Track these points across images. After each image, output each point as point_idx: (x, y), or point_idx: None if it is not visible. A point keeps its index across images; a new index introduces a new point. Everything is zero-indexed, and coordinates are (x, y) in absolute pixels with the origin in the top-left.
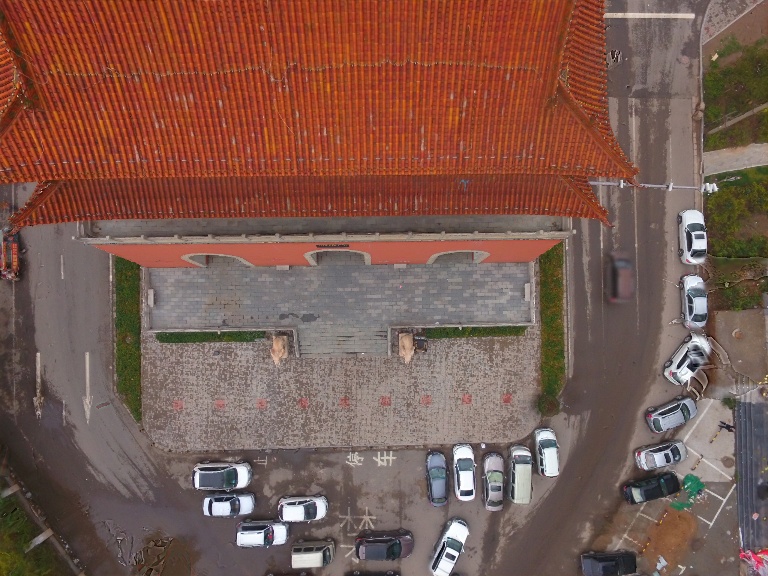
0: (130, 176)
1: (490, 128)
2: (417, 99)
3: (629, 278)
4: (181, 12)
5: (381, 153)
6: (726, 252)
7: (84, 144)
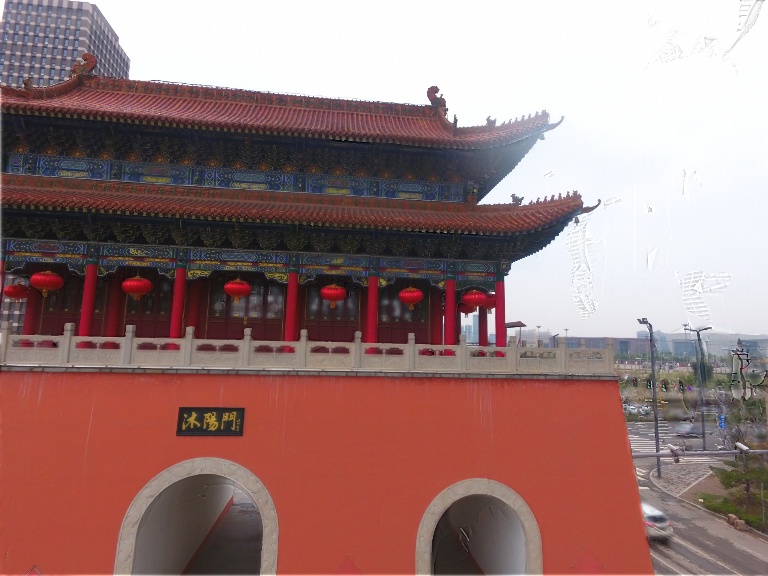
0: (57, 107)
1: None
2: None
3: None
4: None
5: None
6: None
7: None
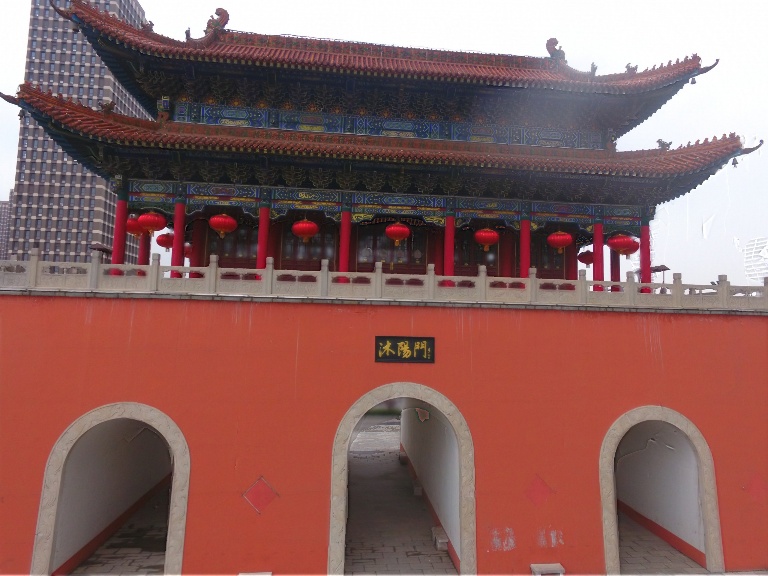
0: (233, 54)
1: None
2: None
3: None
4: None
5: None
6: None
7: None
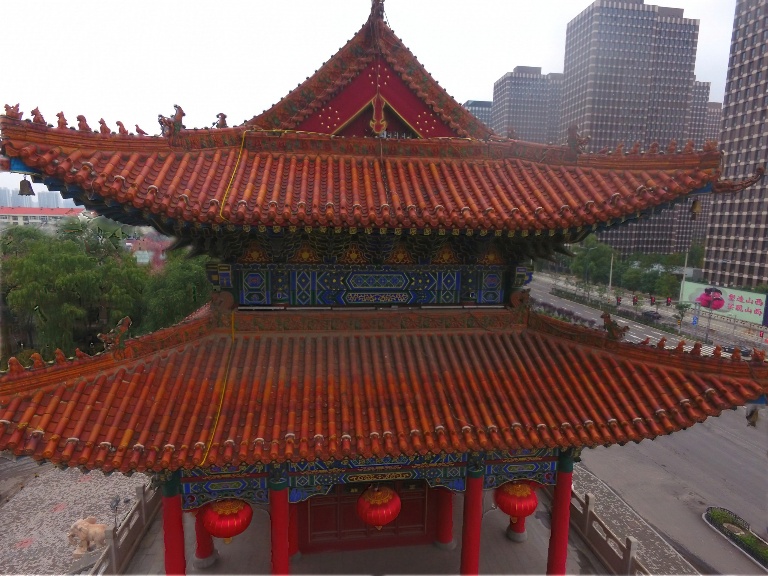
0: None
1: None
2: None
3: None
4: None
5: None
6: None
7: None
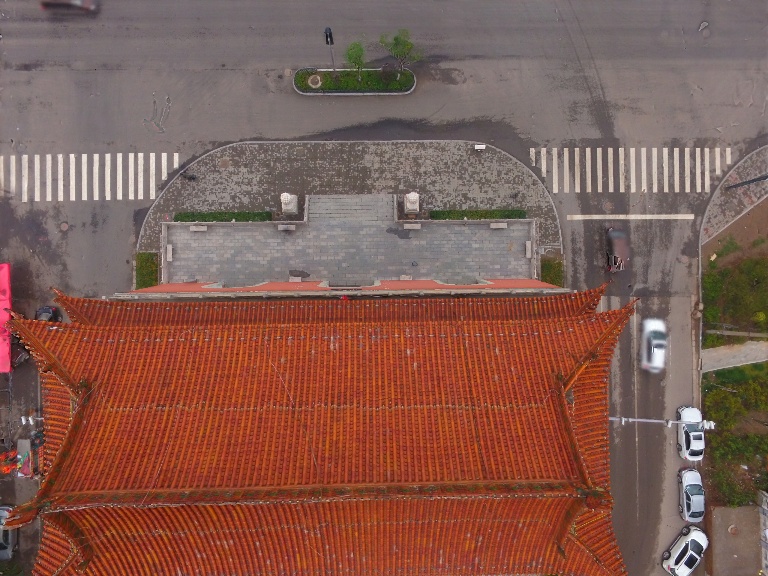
0: None
1: (503, 548)
2: (437, 537)
3: (629, 470)
4: (226, 505)
5: (403, 565)
6: (723, 451)
7: (131, 567)
